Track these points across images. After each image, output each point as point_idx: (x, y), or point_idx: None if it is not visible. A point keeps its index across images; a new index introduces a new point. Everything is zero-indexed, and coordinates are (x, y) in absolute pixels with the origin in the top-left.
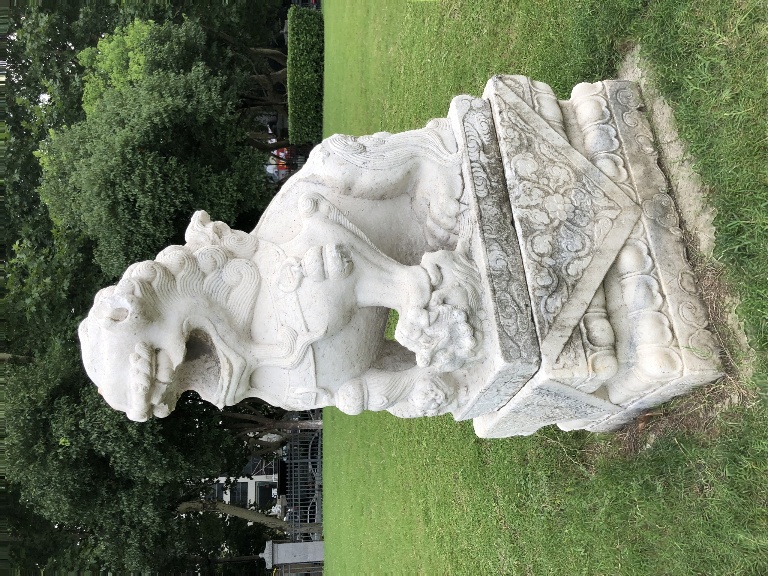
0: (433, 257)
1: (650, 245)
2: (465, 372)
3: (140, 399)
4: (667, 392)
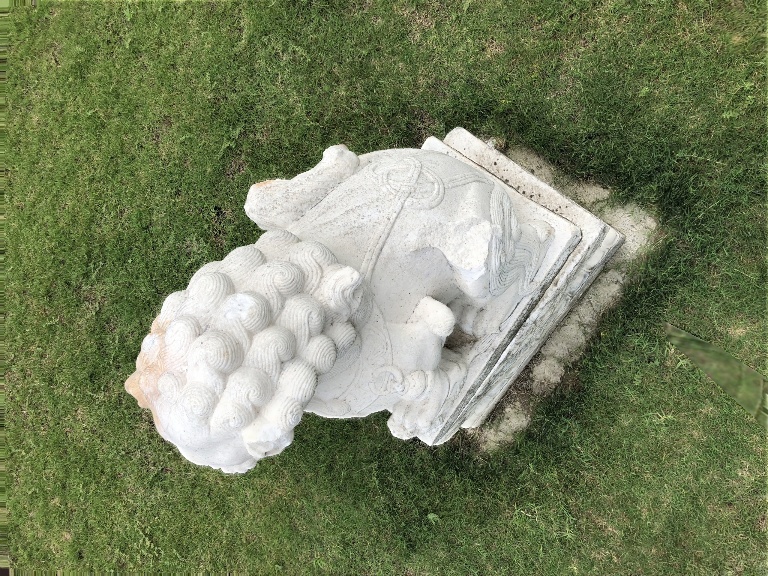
0: (459, 377)
1: (525, 360)
2: None
3: None
4: None
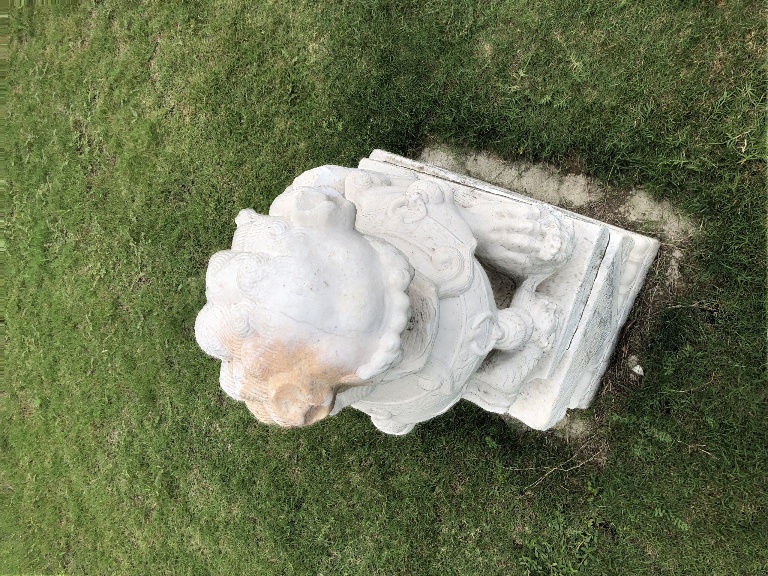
0: (481, 198)
1: None
2: (546, 298)
3: (406, 295)
4: (638, 284)
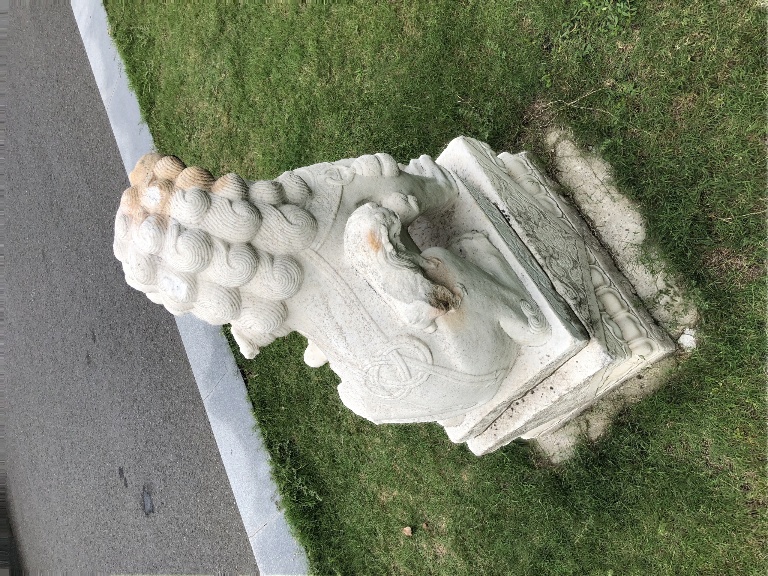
0: None
1: None
2: None
3: None
4: None
